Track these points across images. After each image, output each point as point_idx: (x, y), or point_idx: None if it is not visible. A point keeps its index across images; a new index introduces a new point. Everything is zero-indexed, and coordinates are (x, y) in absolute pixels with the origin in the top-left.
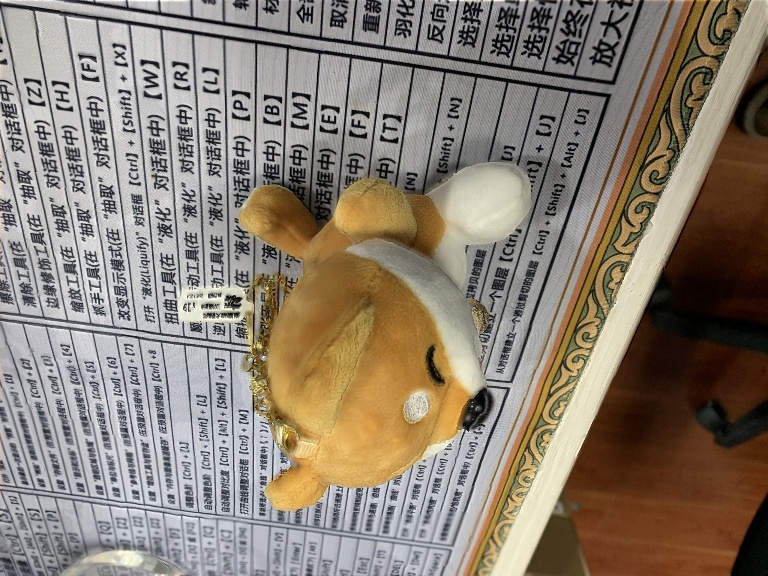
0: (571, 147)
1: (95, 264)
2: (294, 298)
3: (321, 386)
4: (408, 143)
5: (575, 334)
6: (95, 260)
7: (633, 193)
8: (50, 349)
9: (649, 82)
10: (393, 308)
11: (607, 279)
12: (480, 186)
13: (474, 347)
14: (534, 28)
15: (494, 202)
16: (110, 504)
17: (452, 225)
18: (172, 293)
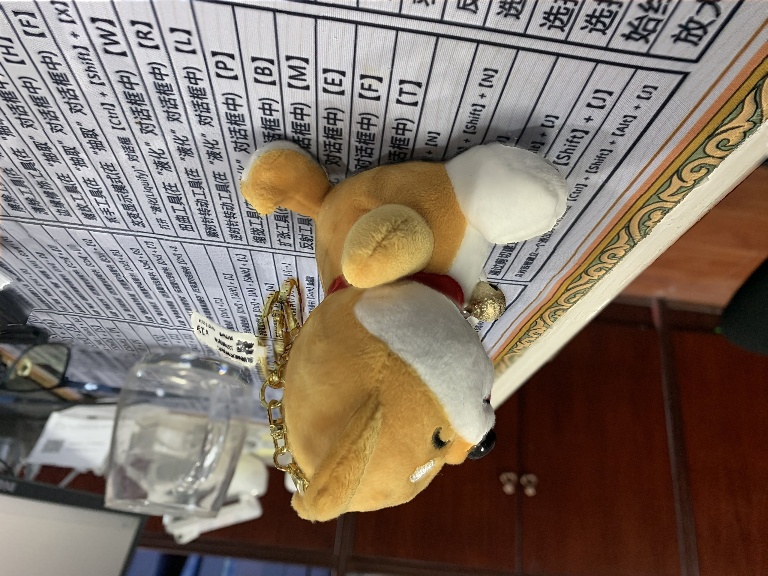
0: (627, 119)
1: (96, 187)
2: (304, 367)
3: (333, 498)
4: (429, 107)
5: (601, 254)
6: (95, 184)
7: (693, 157)
8: (73, 241)
9: (745, 60)
10: (401, 404)
11: (644, 219)
12: (508, 203)
13: (481, 405)
14: (603, 1)
15: (521, 223)
16: (161, 326)
17: (474, 227)
18: (182, 211)
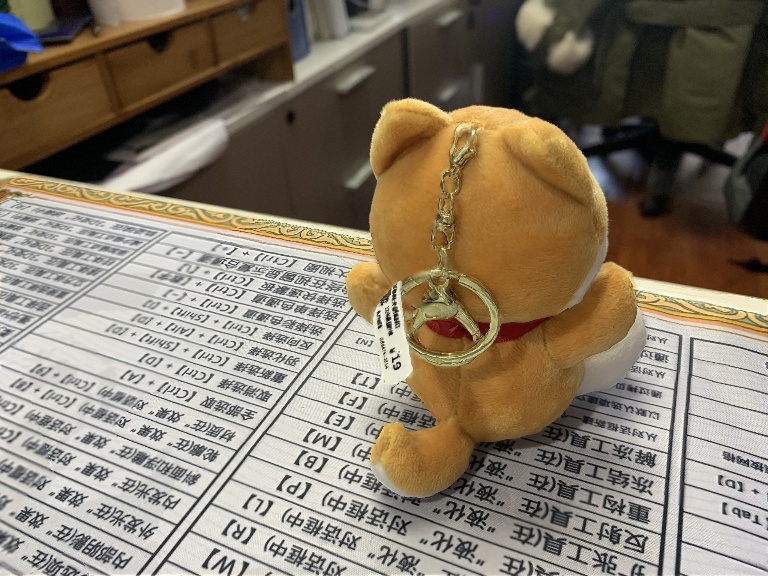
0: None
1: None
2: None
3: None
4: None
5: None
6: None
7: None
8: None
9: None
10: None
11: None
12: None
13: None
14: (328, 302)
15: None
16: None
17: None
18: None
